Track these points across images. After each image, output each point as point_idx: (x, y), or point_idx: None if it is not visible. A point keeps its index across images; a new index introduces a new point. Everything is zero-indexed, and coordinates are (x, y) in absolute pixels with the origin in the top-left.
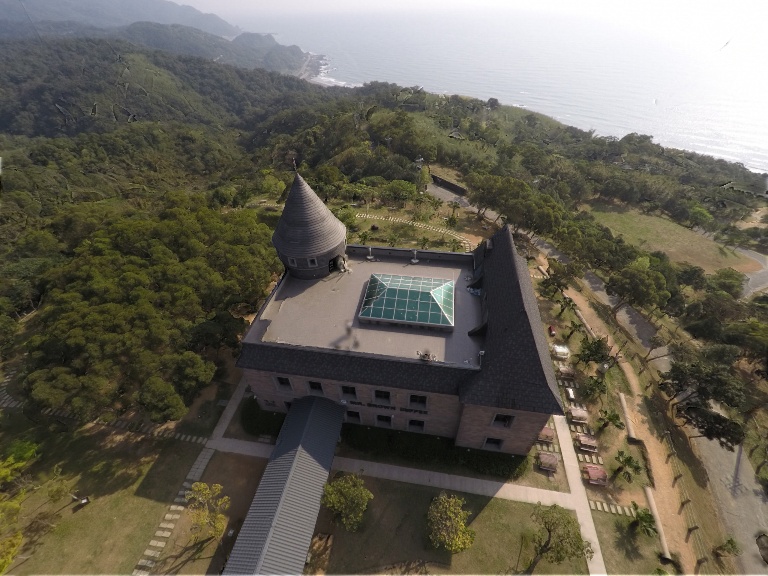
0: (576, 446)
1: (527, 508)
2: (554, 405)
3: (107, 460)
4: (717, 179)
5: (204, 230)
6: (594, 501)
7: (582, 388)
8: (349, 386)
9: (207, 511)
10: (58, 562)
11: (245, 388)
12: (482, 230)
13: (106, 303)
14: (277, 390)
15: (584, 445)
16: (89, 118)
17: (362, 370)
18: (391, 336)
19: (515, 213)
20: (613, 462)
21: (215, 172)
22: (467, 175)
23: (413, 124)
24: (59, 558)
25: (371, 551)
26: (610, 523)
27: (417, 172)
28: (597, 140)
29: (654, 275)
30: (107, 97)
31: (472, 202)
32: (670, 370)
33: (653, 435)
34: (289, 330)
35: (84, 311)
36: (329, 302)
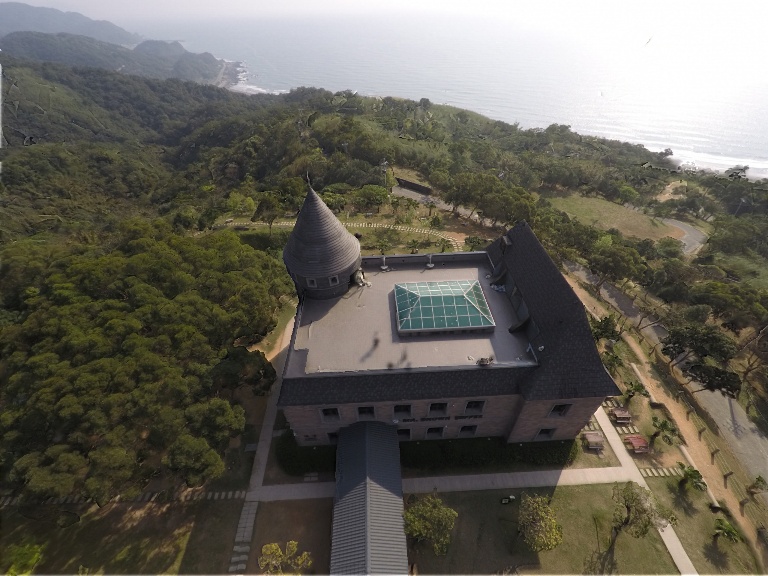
0: (612, 420)
1: (589, 489)
2: (612, 387)
3: (132, 543)
4: (630, 160)
5: (186, 260)
6: (643, 469)
7: None
8: (404, 404)
9: None
10: None
11: (272, 426)
12: (462, 227)
13: (95, 359)
14: (322, 423)
15: (619, 418)
16: None
17: (419, 386)
18: (436, 345)
19: (492, 207)
20: (647, 429)
21: (142, 193)
22: (431, 174)
23: (362, 128)
24: None
25: (460, 570)
26: (663, 486)
27: (381, 175)
28: (526, 132)
29: (629, 251)
30: None
31: (447, 200)
32: (670, 335)
33: (670, 397)
34: (328, 356)
35: (72, 373)
36: (359, 320)
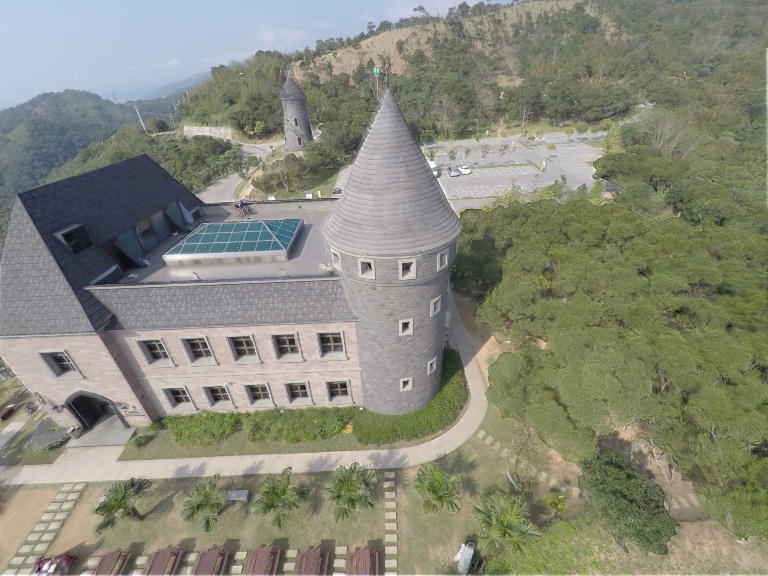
0: None
1: None
2: None
3: None
4: None
5: None
6: None
7: None
8: None
9: None
10: None
11: None
12: None
13: None
14: None
15: None
16: None
17: None
18: None
19: None
20: None
21: None
22: None
23: None
24: None
25: None
26: None
27: None
28: None
29: None
30: None
31: None
32: None
33: None
34: None
35: (608, 206)
36: None
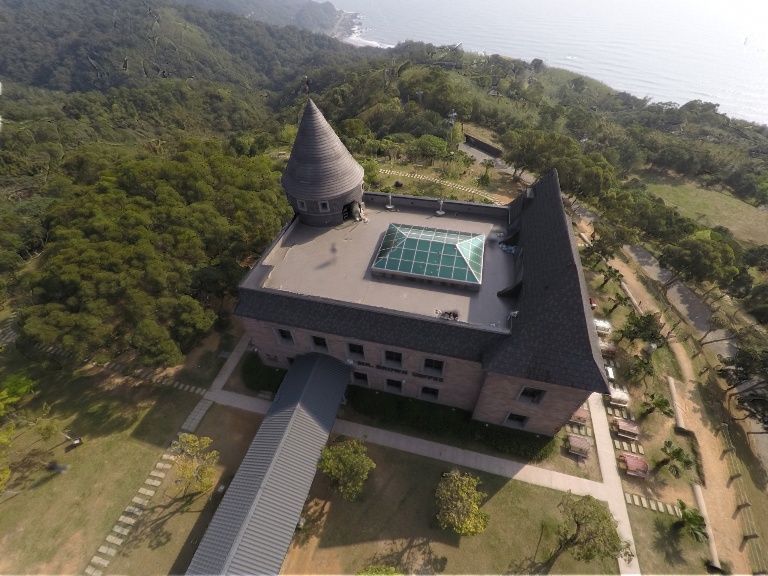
0: (613, 431)
1: (550, 494)
2: (598, 381)
3: (103, 403)
4: None
5: (214, 173)
6: (631, 494)
7: (623, 368)
8: (356, 344)
9: (196, 464)
10: (47, 500)
11: (249, 341)
12: (517, 192)
13: (105, 241)
14: (279, 344)
15: (622, 431)
16: (120, 73)
17: (371, 326)
18: (407, 291)
19: None
20: (656, 453)
21: None
22: (504, 134)
23: (448, 80)
24: (48, 496)
25: (370, 523)
26: (649, 521)
27: (449, 129)
28: (653, 107)
29: (720, 247)
30: (138, 52)
31: (508, 161)
32: (735, 355)
33: (706, 427)
34: (293, 279)
35: (81, 247)
36: (340, 252)
